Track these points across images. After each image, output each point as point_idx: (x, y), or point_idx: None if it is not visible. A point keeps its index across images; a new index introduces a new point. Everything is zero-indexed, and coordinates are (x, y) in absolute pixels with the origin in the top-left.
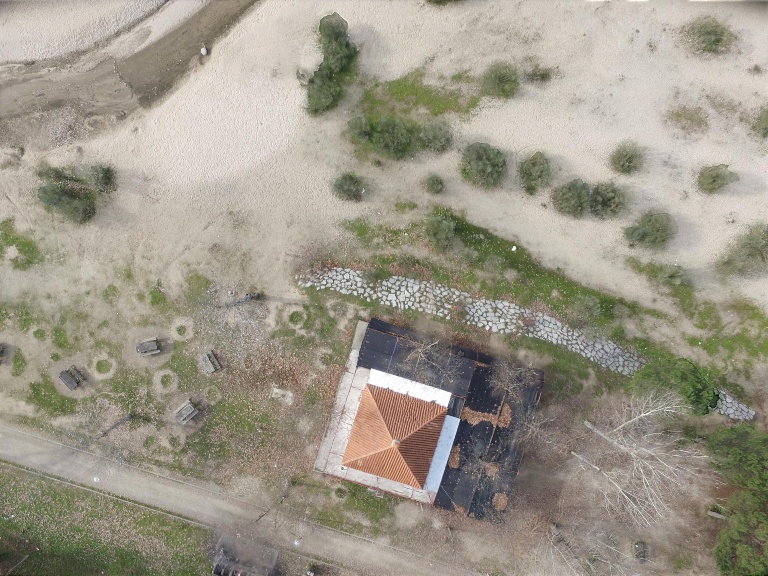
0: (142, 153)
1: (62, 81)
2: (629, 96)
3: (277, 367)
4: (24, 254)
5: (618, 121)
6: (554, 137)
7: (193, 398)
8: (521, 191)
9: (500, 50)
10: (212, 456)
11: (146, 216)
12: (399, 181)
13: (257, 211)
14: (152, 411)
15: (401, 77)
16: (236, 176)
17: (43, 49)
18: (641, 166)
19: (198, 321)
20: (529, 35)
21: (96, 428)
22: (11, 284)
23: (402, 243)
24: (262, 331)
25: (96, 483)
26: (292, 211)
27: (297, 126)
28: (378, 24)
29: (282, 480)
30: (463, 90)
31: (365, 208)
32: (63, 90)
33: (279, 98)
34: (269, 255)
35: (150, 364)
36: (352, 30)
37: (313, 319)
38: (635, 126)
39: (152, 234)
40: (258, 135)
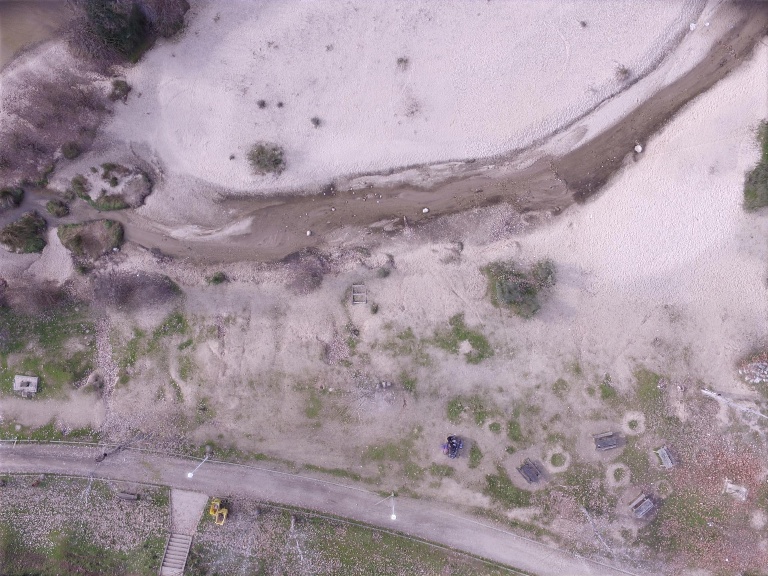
0: (579, 248)
1: (500, 178)
2: None
3: (729, 462)
4: (477, 348)
5: None
6: None
7: (644, 491)
8: None
9: None
10: (663, 549)
11: (585, 310)
12: None
13: (691, 305)
14: (604, 504)
15: None
16: (671, 270)
17: (485, 148)
18: None
19: (649, 416)
20: None
21: (550, 520)
22: (464, 377)
23: None
24: (714, 426)
25: (548, 574)
26: (726, 305)
27: (732, 222)
28: None
29: (734, 574)
30: None
31: None
32: (500, 187)
33: (716, 195)
34: (709, 349)
35: (603, 458)
36: None
37: (767, 416)
38: None
39: (594, 328)
40: (694, 231)
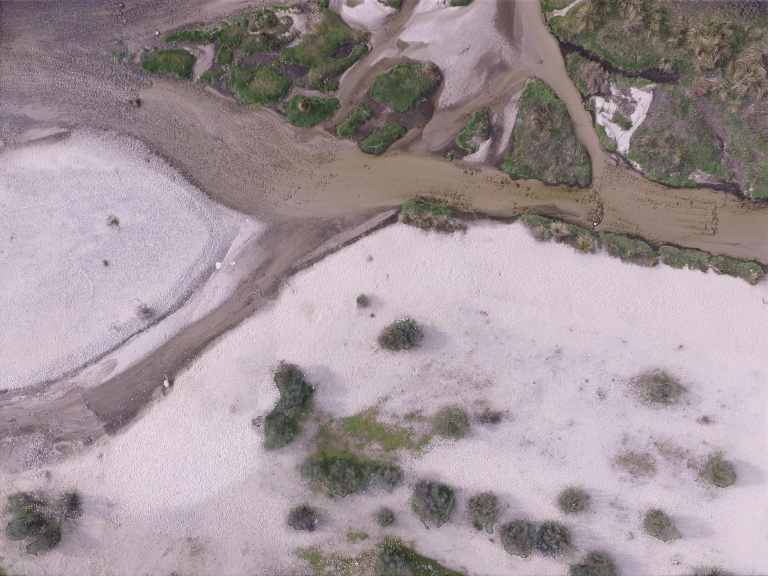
0: (106, 480)
1: (32, 408)
2: (577, 440)
3: None
4: None
5: (566, 463)
6: (503, 476)
7: None
8: (469, 526)
9: (451, 393)
10: None
11: (108, 542)
12: (351, 512)
13: (214, 537)
14: None
15: (355, 414)
16: (195, 504)
17: (15, 381)
18: (588, 506)
19: None
20: (480, 381)
21: None
22: None
23: (352, 572)
24: None
25: None
26: (247, 539)
27: (254, 459)
28: (333, 365)
29: None
30: (415, 429)
31: (318, 537)
32: (33, 416)
33: (237, 432)
34: None
35: None
36: (308, 370)
37: None
38: (583, 468)
39: (114, 561)
40: (216, 467)
